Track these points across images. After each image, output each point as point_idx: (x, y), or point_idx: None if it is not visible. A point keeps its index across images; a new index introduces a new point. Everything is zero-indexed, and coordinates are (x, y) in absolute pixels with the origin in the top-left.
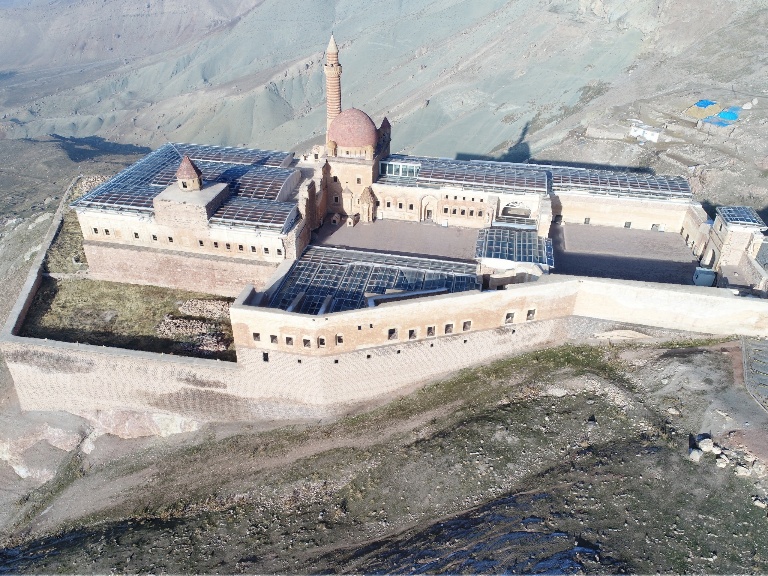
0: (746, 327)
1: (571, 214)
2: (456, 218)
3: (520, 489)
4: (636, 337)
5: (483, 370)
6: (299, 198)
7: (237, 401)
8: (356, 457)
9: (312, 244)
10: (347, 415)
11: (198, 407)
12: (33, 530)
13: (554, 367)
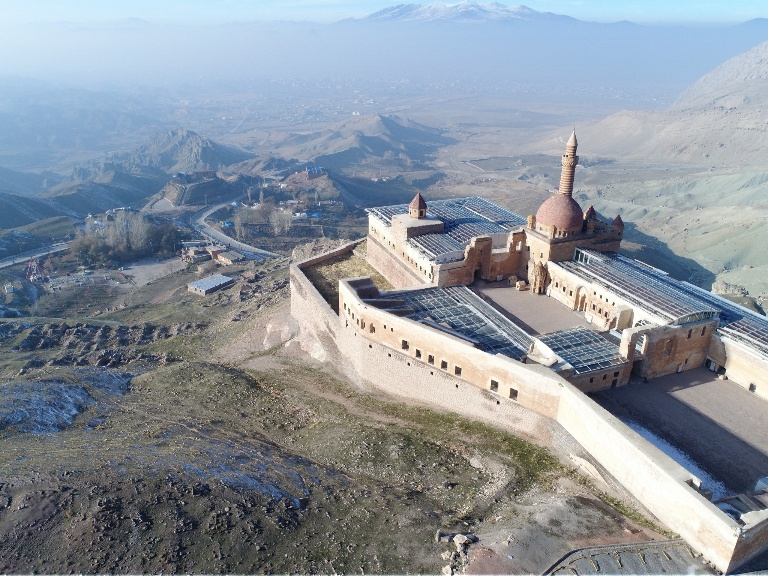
0: (689, 532)
1: (735, 371)
2: (599, 318)
3: (351, 475)
4: (598, 478)
5: (463, 421)
6: (468, 245)
7: (338, 352)
8: (339, 413)
9: (471, 287)
10: (371, 395)
11: (328, 347)
12: (240, 365)
13: (504, 451)
